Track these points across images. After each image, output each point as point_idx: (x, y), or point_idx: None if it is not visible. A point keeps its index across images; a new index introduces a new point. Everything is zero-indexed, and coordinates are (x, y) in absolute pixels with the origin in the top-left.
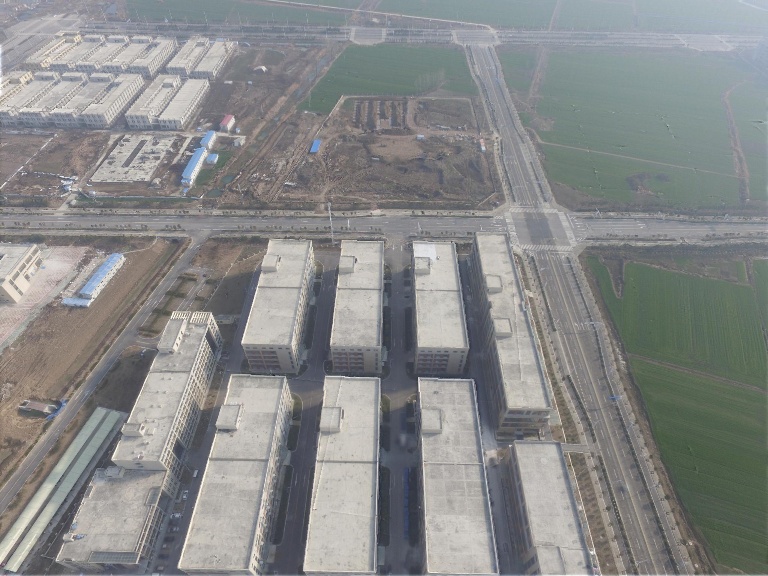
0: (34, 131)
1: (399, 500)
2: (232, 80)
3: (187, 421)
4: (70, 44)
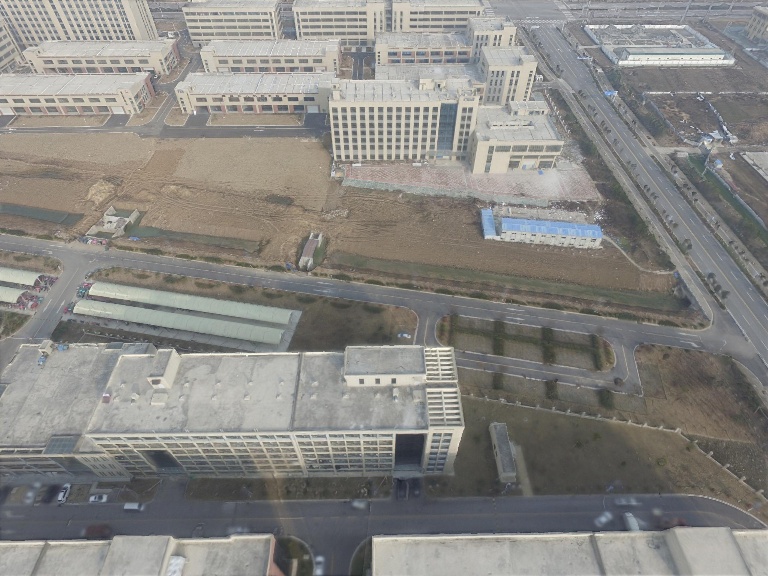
0: None
1: None
2: None
3: (218, 457)
4: None
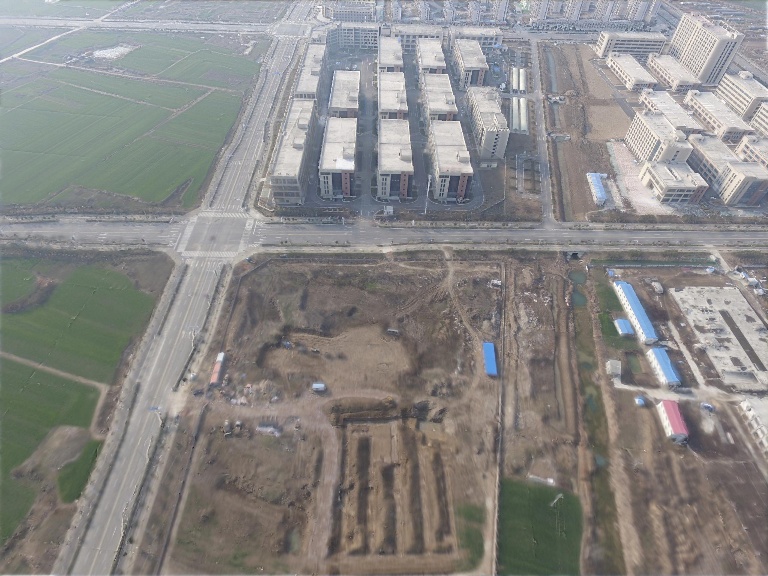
0: None
1: (368, 109)
2: None
3: None
4: None
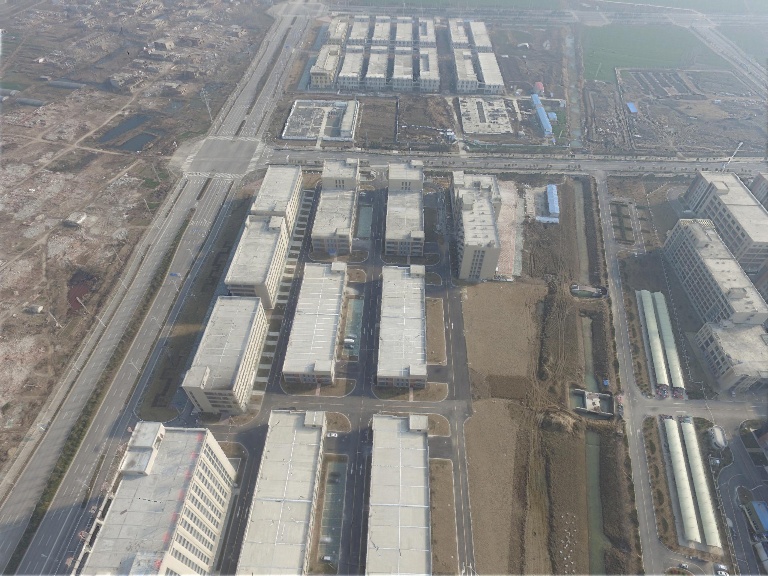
0: (378, 94)
1: None
2: (507, 54)
3: None
4: (346, 23)
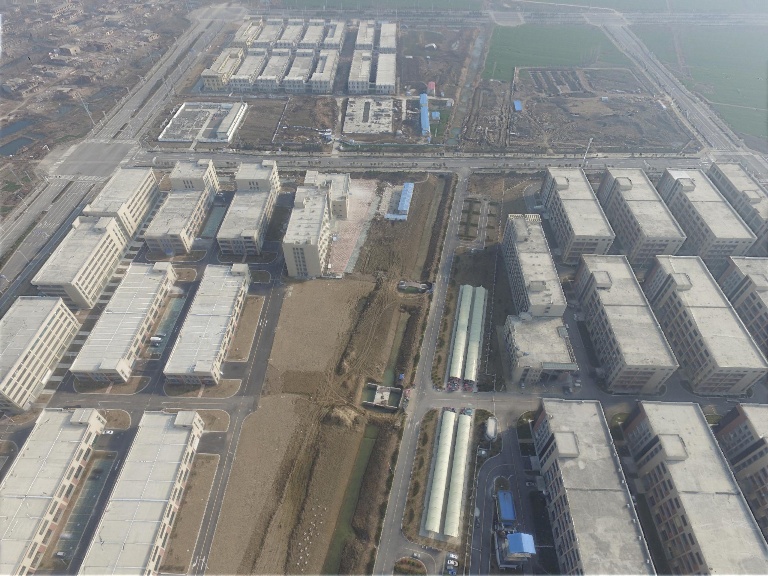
0: (269, 96)
1: None
2: (412, 55)
3: None
4: (257, 26)
